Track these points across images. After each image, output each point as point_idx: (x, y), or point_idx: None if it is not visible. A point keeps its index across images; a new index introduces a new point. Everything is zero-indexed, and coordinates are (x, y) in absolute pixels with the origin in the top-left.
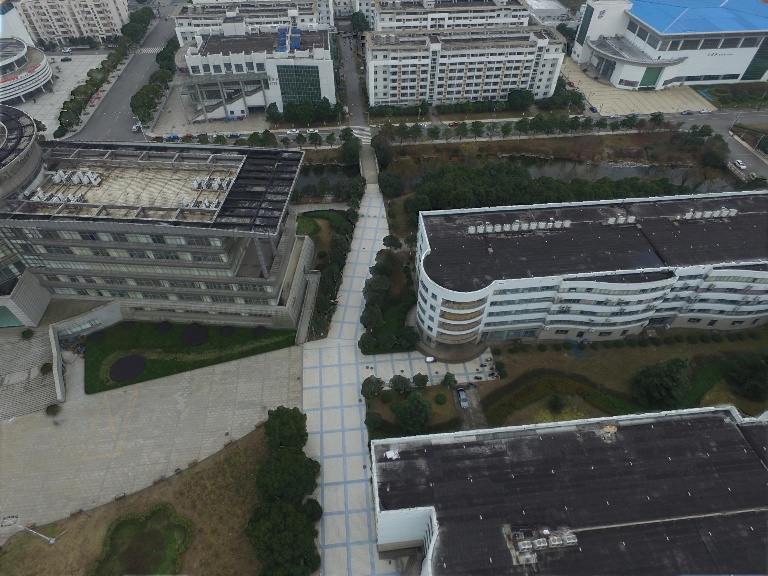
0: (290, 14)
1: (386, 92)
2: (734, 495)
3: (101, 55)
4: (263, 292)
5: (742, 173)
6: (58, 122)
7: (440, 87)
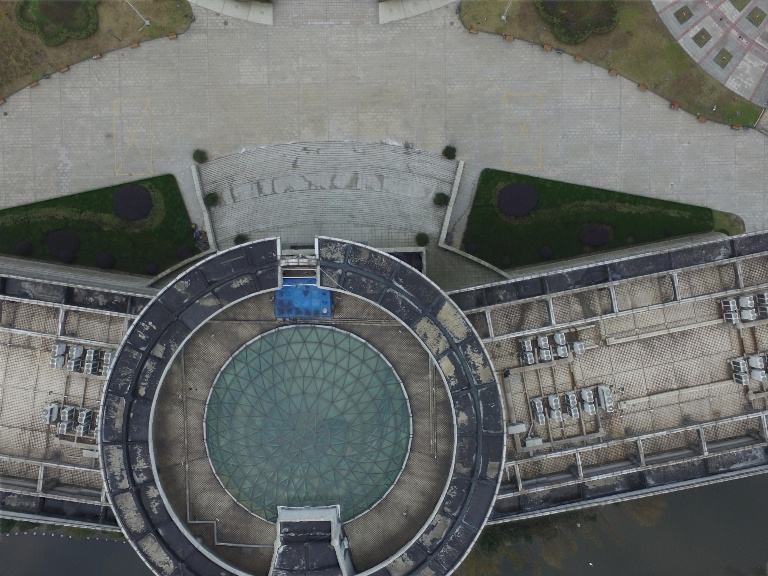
0: None
1: None
2: None
3: None
4: None
5: None
6: None
7: None
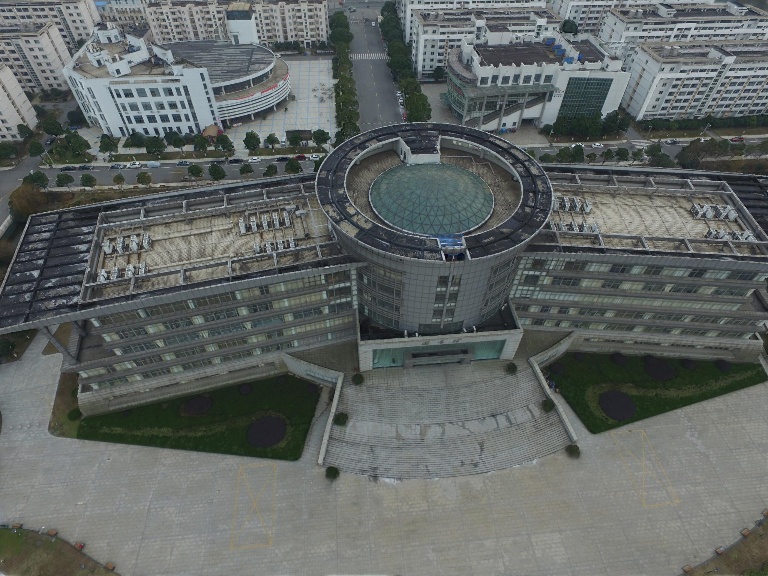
0: (539, 22)
1: (656, 105)
2: None
3: (313, 61)
4: (752, 326)
5: None
6: None
7: (712, 100)
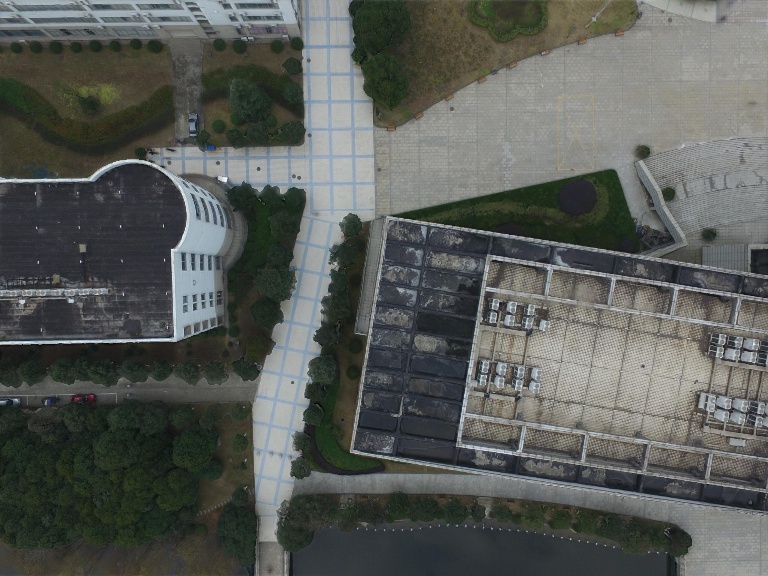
0: None
1: None
2: None
3: None
4: None
5: None
6: None
7: None
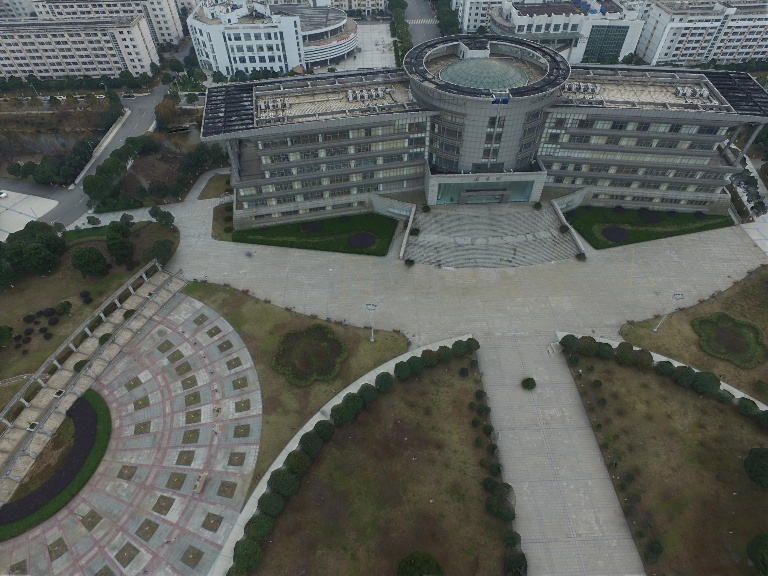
0: None
1: (668, 52)
2: None
3: (374, 25)
4: (721, 180)
5: None
6: None
7: (717, 49)
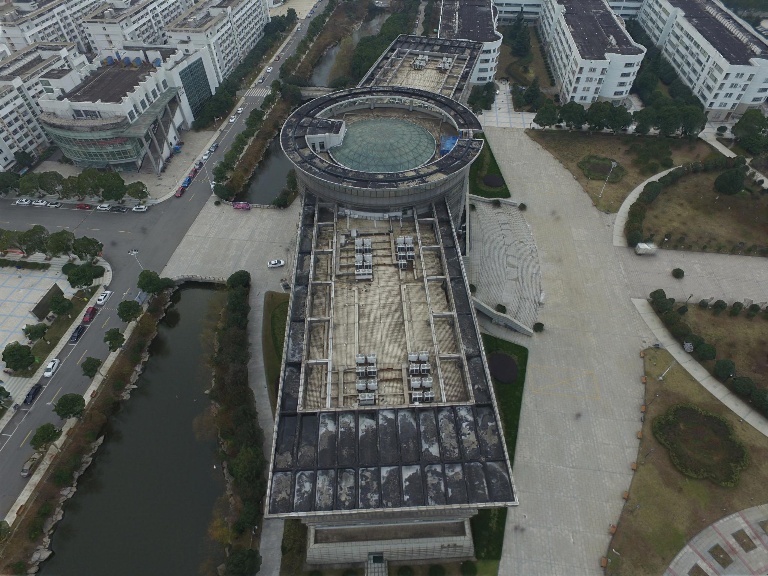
0: (62, 55)
1: (220, 66)
2: (590, 19)
3: None
4: None
5: (386, 4)
6: (47, 283)
7: None
